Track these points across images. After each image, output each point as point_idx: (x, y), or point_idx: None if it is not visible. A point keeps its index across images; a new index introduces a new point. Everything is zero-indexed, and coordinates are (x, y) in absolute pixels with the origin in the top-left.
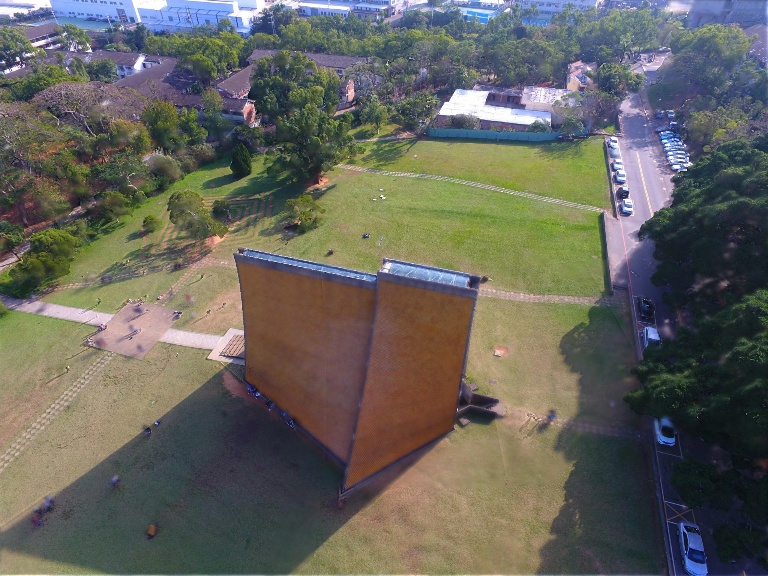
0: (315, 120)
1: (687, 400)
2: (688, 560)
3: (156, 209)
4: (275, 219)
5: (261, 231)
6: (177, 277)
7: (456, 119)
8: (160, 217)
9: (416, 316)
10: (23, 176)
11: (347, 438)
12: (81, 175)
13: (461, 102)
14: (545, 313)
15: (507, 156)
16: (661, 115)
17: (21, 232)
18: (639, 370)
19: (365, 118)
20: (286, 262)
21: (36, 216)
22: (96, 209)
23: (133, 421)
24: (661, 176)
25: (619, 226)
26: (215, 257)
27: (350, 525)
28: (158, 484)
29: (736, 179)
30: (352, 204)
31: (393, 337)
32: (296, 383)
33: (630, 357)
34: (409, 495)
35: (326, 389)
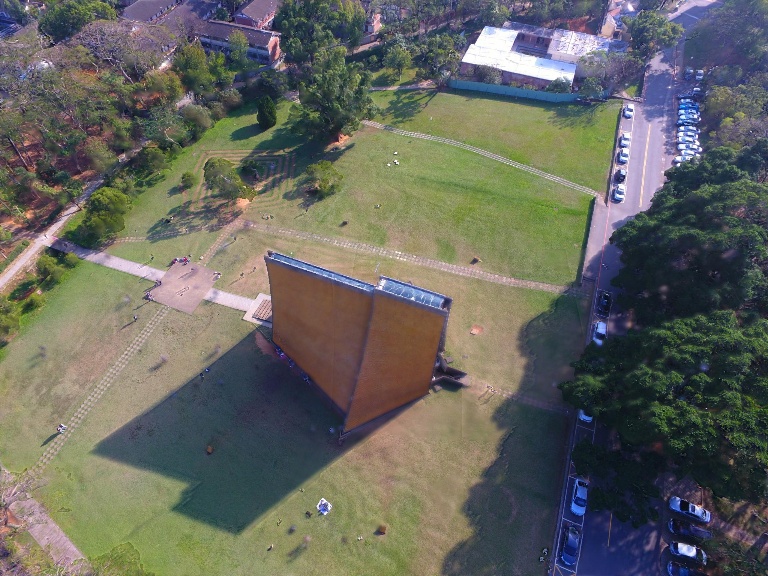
0: (337, 81)
1: (597, 400)
2: (574, 504)
3: (191, 161)
4: (298, 181)
5: (285, 194)
6: (214, 238)
7: (478, 69)
8: (195, 171)
9: (402, 320)
10: (76, 135)
11: (347, 396)
12: (124, 130)
13: (487, 45)
14: (520, 298)
15: (521, 119)
16: (689, 75)
17: (80, 186)
18: (575, 366)
19: (388, 63)
20: (305, 267)
21: (86, 161)
22: (138, 157)
23: (189, 367)
24: (664, 156)
25: (606, 214)
26: (246, 219)
27: (346, 458)
28: (211, 417)
29: (702, 202)
30: (368, 168)
31: (384, 332)
32: (311, 351)
33: (579, 346)
34: (390, 440)
35: (333, 359)
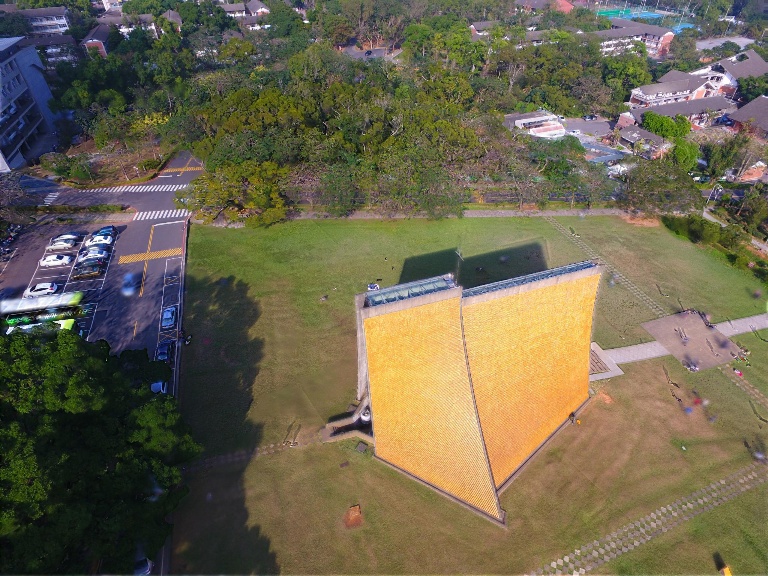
0: None
1: None
2: None
3: None
4: None
5: None
6: None
7: None
8: None
9: None
10: None
11: None
12: None
13: None
14: None
15: None
16: None
17: None
18: None
19: None
20: None
21: None
22: None
23: None
24: None
25: None
26: None
27: None
28: None
29: None
30: None
31: None
32: None
33: None
34: None
35: None
